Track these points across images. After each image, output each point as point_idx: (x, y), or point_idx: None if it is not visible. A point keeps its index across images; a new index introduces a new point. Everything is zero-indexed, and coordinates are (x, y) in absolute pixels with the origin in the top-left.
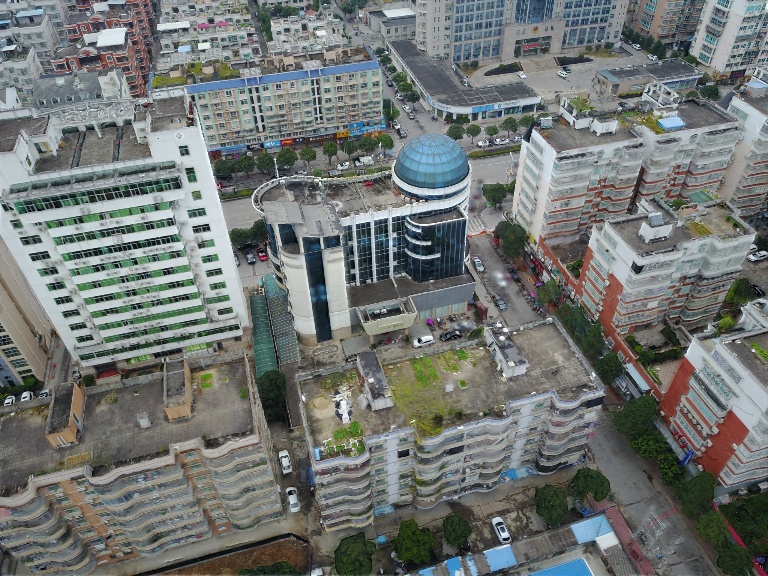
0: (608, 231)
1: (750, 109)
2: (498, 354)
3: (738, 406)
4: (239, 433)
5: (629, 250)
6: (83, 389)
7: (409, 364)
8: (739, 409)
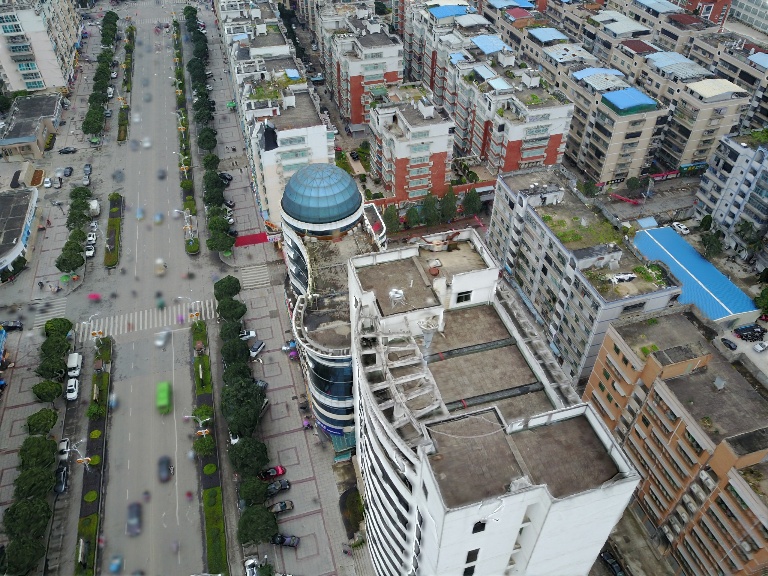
0: (417, 131)
1: (271, 48)
2: (550, 196)
3: (552, 129)
4: (690, 321)
5: (443, 125)
6: (715, 444)
7: (564, 244)
8: (554, 130)
